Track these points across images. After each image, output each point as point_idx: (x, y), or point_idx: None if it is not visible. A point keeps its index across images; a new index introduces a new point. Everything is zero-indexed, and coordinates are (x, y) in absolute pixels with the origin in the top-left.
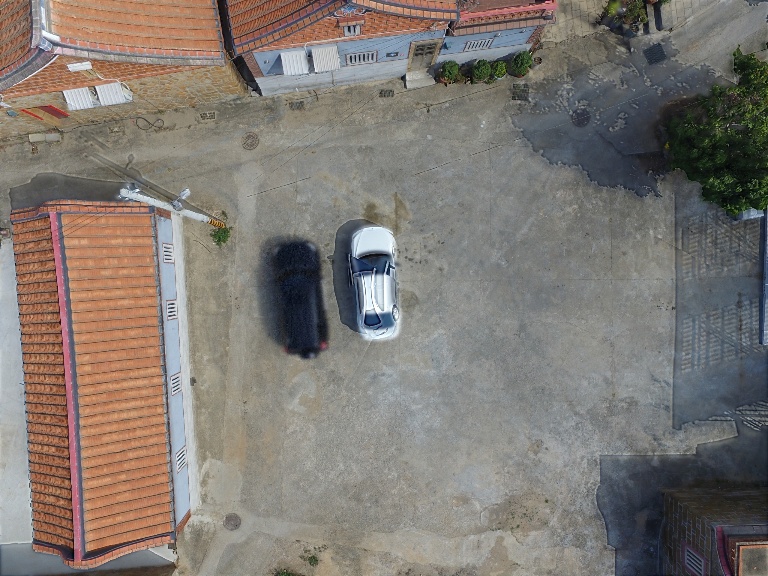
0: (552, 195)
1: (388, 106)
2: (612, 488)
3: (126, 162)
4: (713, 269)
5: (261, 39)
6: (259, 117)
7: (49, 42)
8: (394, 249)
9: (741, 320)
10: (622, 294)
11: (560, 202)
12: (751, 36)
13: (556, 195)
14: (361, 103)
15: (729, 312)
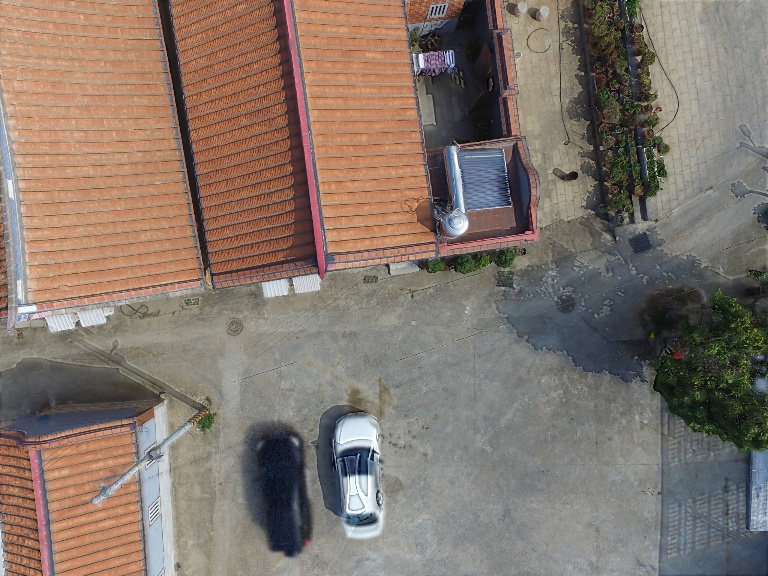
0: (537, 381)
1: (372, 291)
2: None
3: (111, 348)
4: (699, 454)
5: (239, 280)
6: (243, 303)
7: (25, 314)
8: (378, 435)
9: (728, 505)
10: (607, 479)
11: (545, 387)
12: (737, 227)
13: (541, 381)
14: (345, 289)
15: (716, 497)
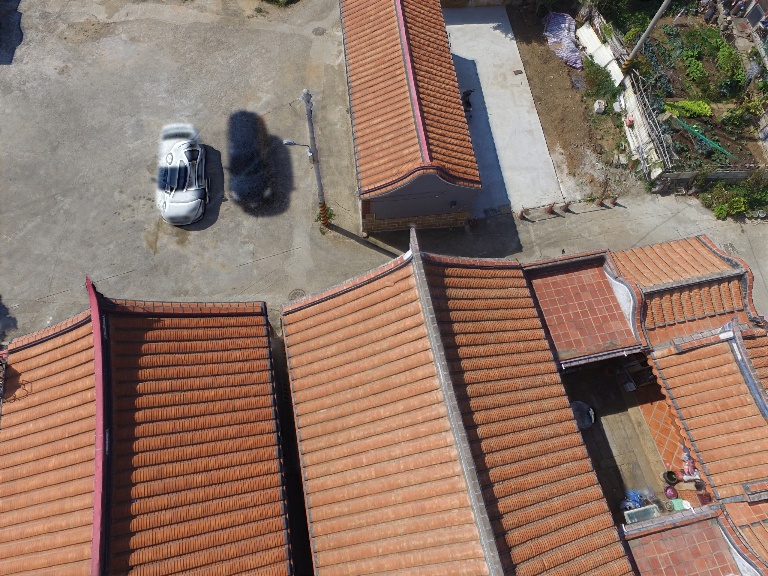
0: None
1: None
2: (7, 45)
3: None
4: None
5: None
6: None
7: None
8: (164, 207)
9: None
10: None
11: None
12: None
13: None
14: None
15: None
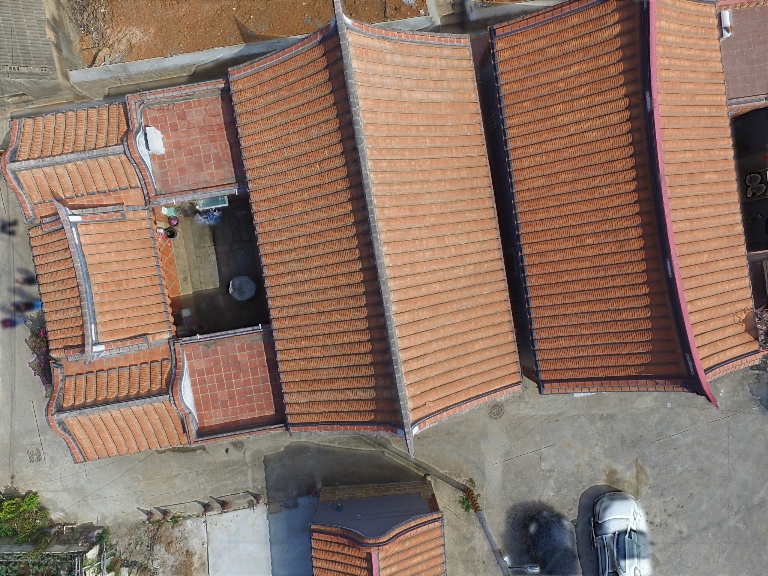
0: None
1: None
2: None
3: None
4: None
5: (574, 388)
6: None
7: None
8: (635, 513)
9: None
10: None
11: None
12: None
13: None
14: None
15: None
